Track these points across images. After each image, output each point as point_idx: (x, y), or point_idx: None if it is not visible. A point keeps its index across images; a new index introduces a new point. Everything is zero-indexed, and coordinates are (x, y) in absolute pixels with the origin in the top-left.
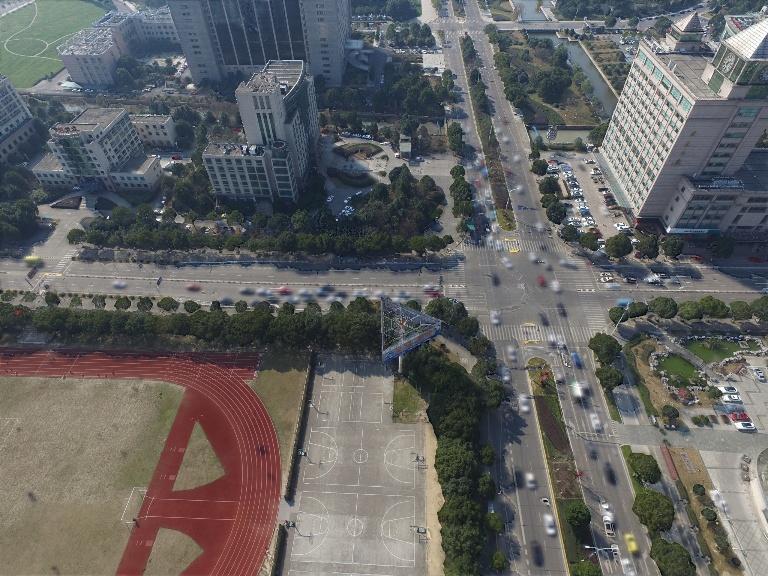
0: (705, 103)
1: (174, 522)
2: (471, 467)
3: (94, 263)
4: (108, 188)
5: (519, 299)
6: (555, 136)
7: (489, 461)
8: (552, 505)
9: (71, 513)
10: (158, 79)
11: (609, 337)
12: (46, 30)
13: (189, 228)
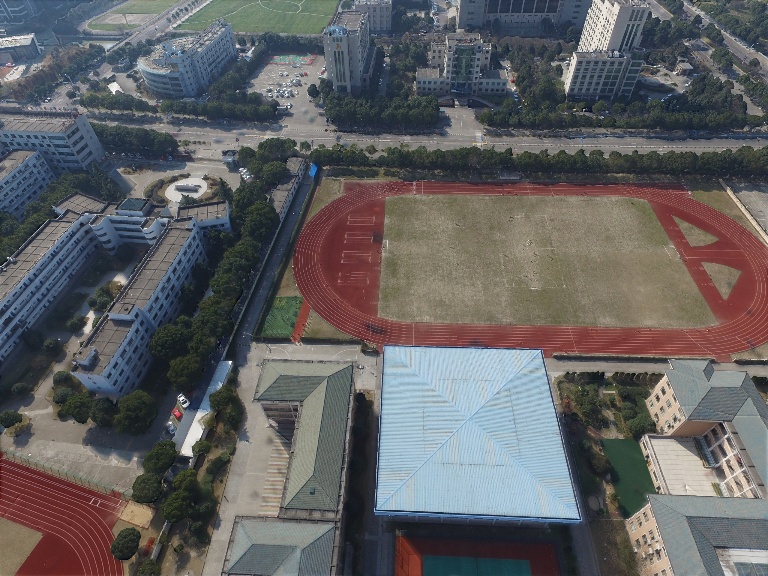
0: None
1: (708, 259)
2: None
3: (503, 137)
4: (472, 93)
5: None
6: None
7: None
8: None
9: (634, 256)
10: (427, 26)
11: None
12: None
13: None
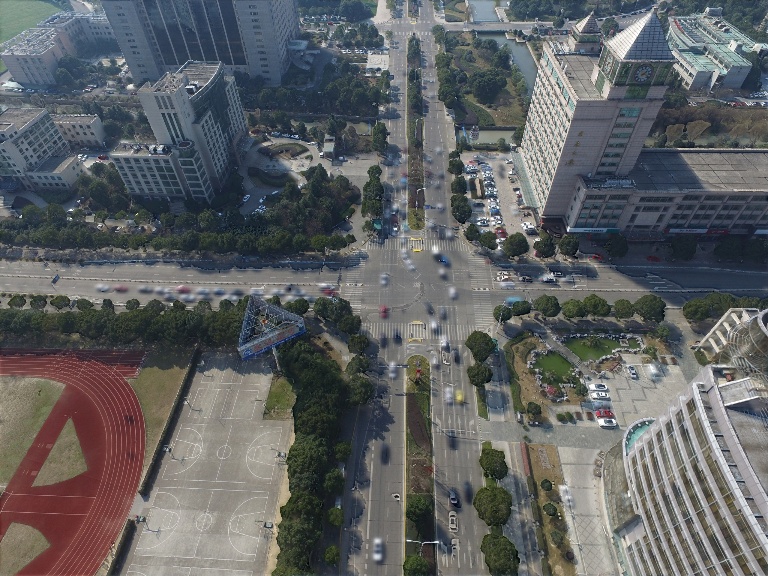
0: (586, 103)
1: (27, 517)
2: (319, 463)
3: (0, 262)
4: (27, 187)
5: (412, 297)
6: (477, 136)
7: (342, 457)
8: (402, 500)
9: None
10: (100, 79)
11: (484, 335)
12: (0, 30)
13: (101, 227)
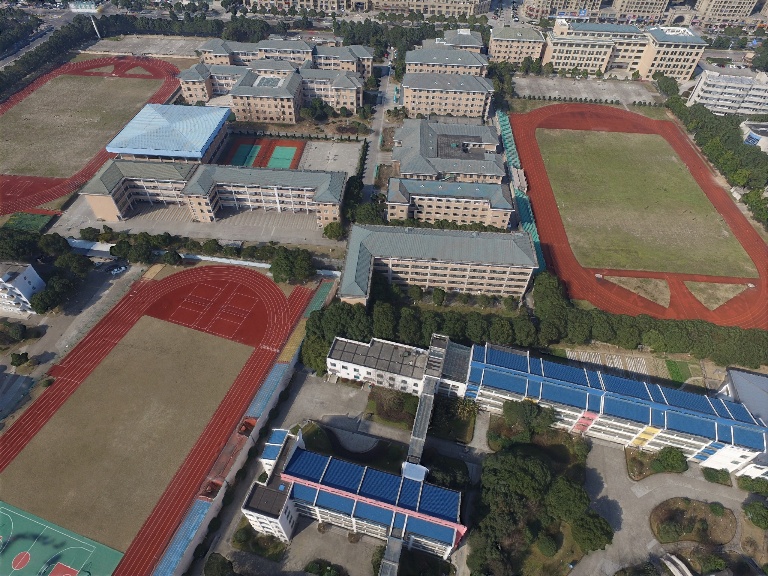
0: None
1: (124, 71)
2: None
3: None
4: None
5: None
6: None
7: None
8: None
9: (103, 88)
10: None
11: None
12: None
13: None
